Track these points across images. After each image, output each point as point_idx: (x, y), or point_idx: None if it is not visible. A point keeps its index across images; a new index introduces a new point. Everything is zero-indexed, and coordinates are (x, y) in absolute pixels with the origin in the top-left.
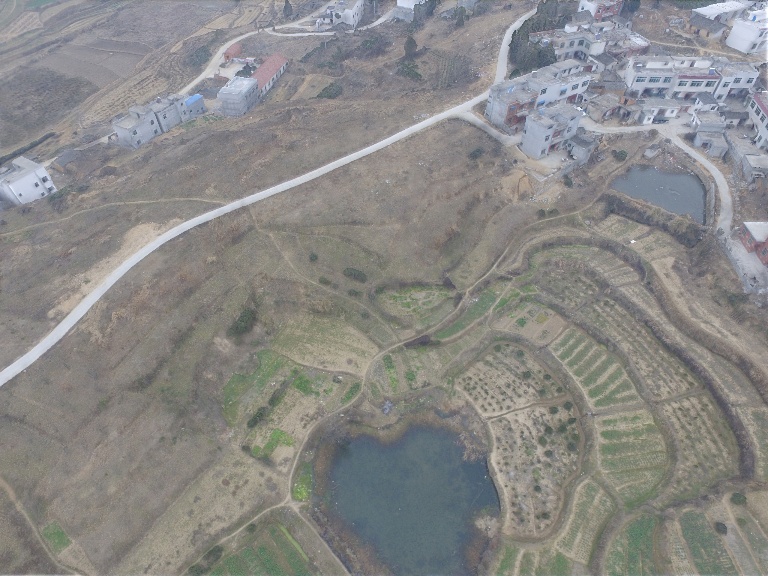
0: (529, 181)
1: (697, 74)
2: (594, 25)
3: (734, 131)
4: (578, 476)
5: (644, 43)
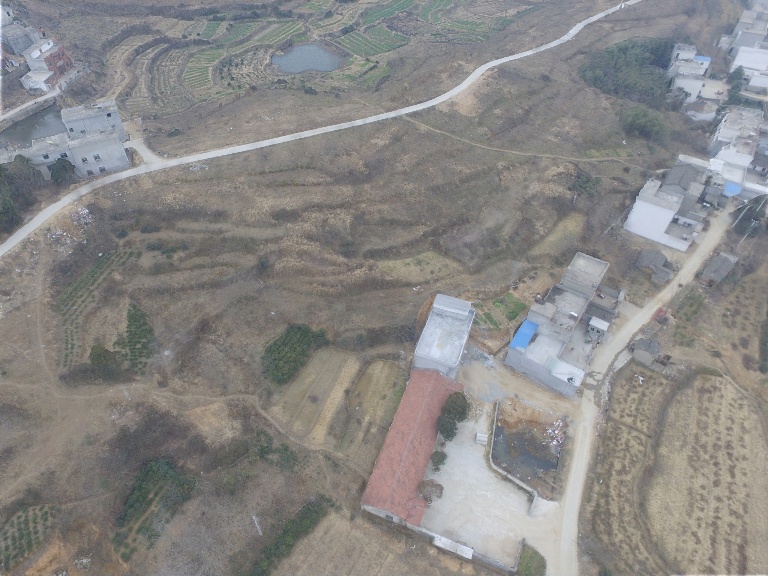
0: None
1: None
2: None
3: None
4: None
5: None
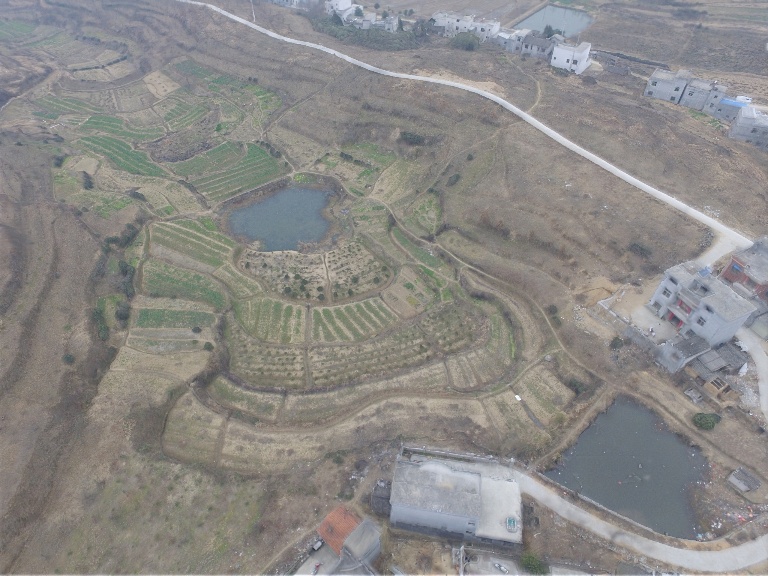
0: None
1: None
2: None
3: None
4: None
5: None
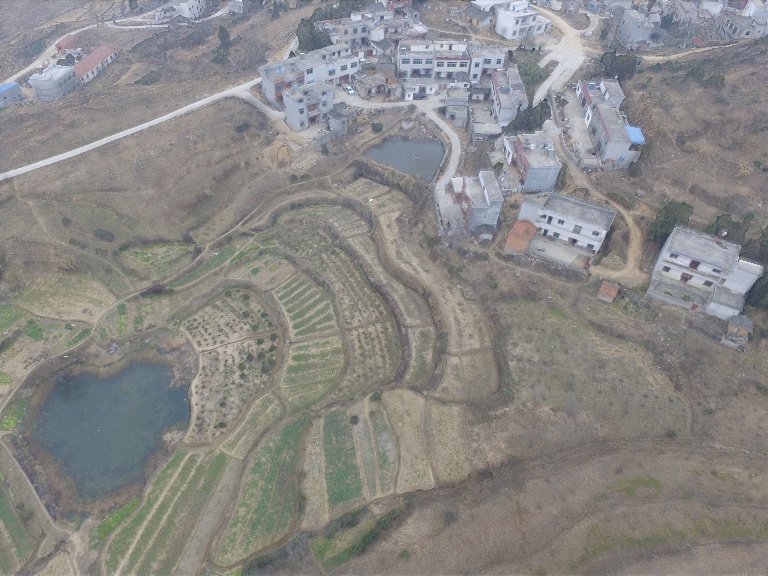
0: (288, 150)
1: (453, 56)
2: (376, 14)
3: (480, 105)
4: (262, 392)
5: (424, 31)
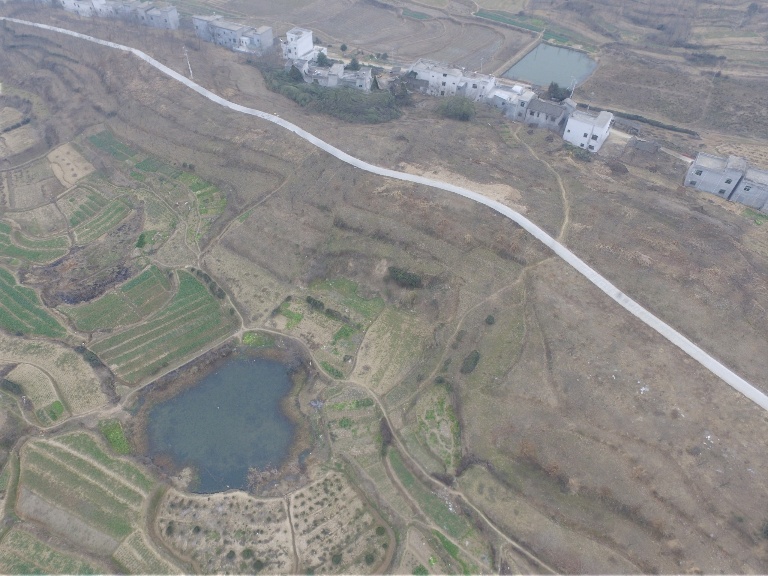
0: None
1: None
2: None
3: None
4: None
5: None
